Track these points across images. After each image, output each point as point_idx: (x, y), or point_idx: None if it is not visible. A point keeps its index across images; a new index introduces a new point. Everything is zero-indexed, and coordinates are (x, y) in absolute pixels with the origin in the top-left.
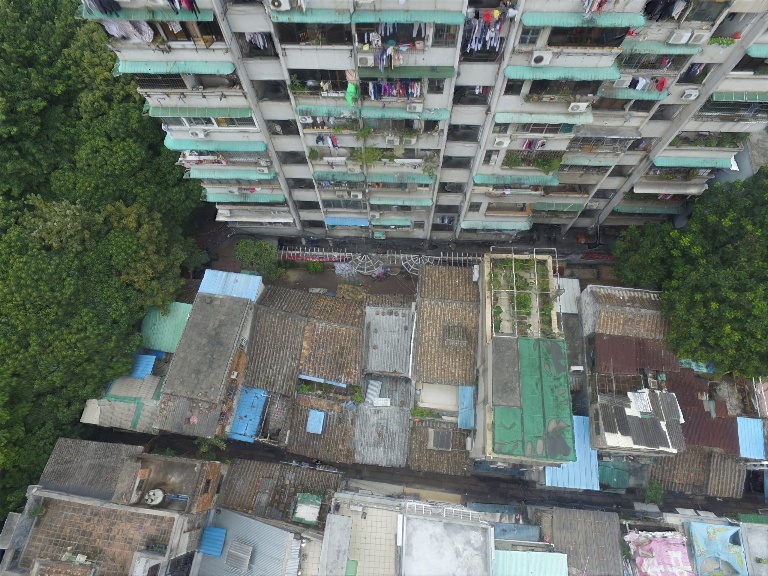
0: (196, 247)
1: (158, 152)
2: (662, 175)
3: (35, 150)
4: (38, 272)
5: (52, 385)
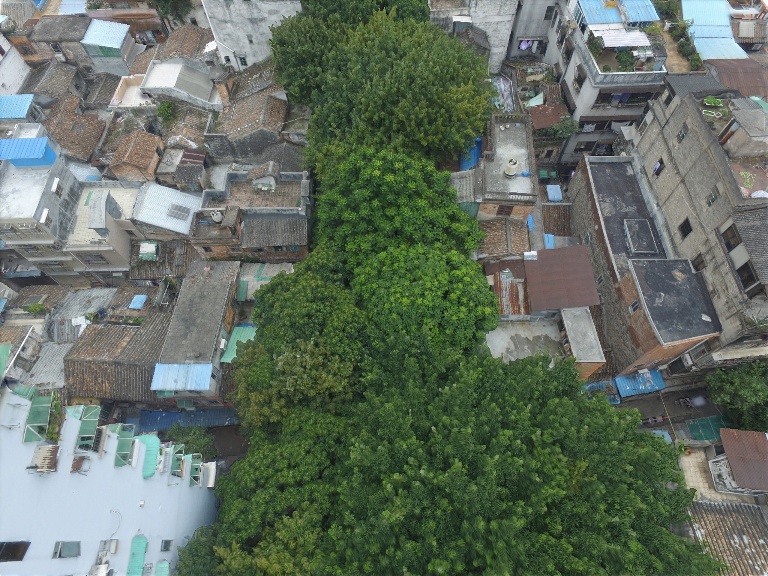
0: None
1: None
2: None
3: None
4: None
5: None
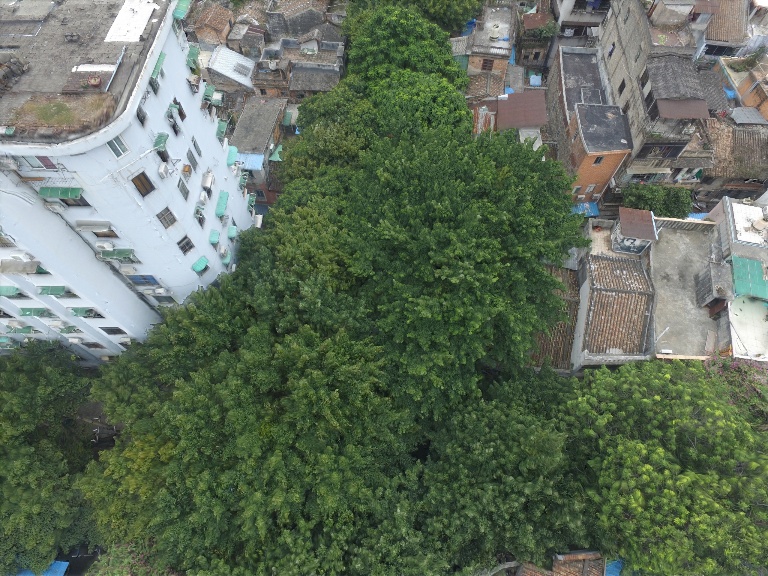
0: None
1: None
2: None
3: None
4: None
5: None
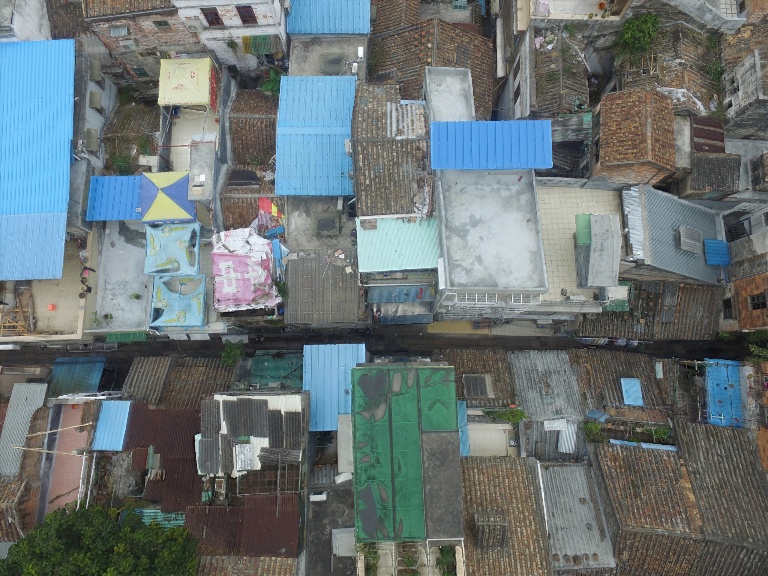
0: None
1: None
2: None
3: None
4: None
5: None
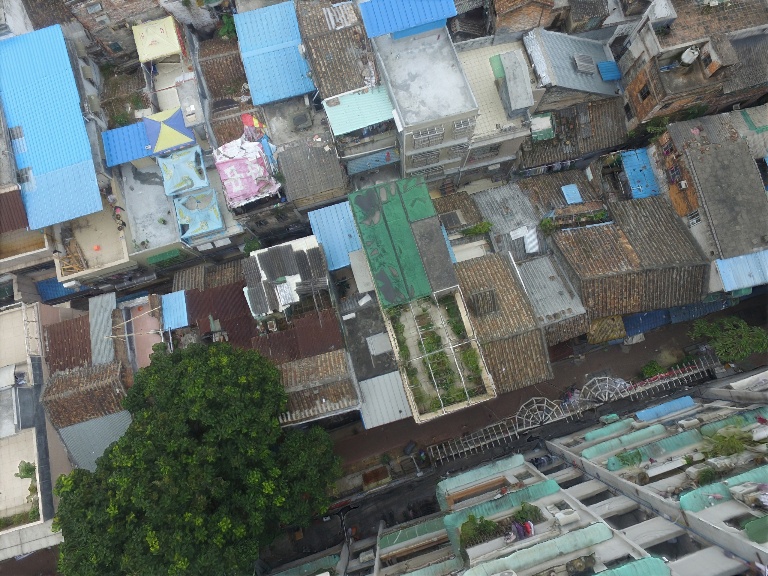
0: None
1: None
2: None
3: None
4: None
5: None
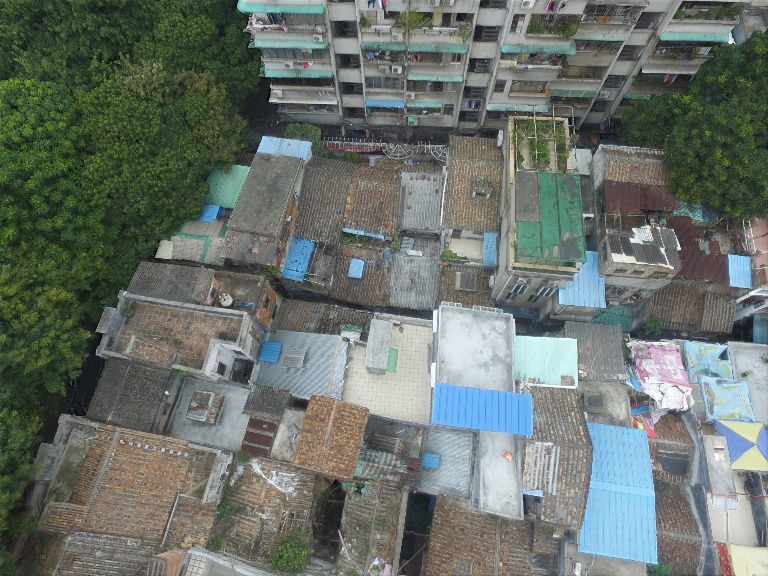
0: (249, 130)
1: (222, 35)
2: (668, 53)
3: (122, 21)
4: (130, 111)
5: (135, 218)
